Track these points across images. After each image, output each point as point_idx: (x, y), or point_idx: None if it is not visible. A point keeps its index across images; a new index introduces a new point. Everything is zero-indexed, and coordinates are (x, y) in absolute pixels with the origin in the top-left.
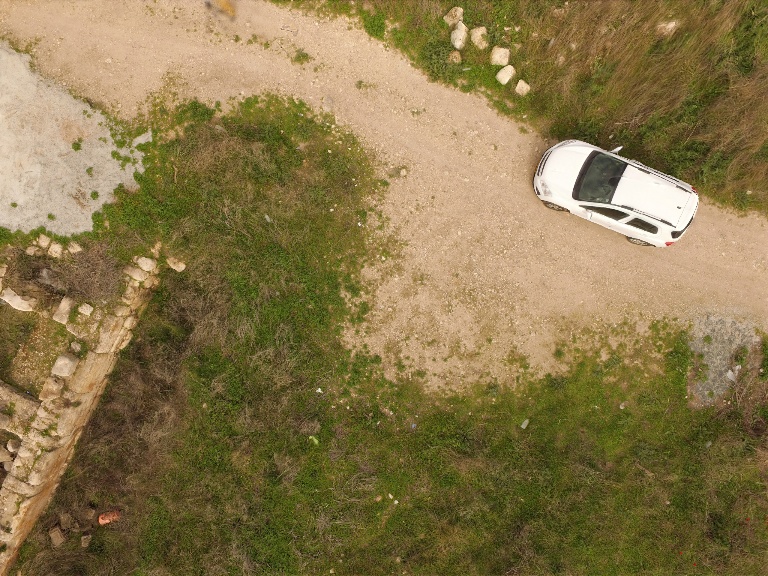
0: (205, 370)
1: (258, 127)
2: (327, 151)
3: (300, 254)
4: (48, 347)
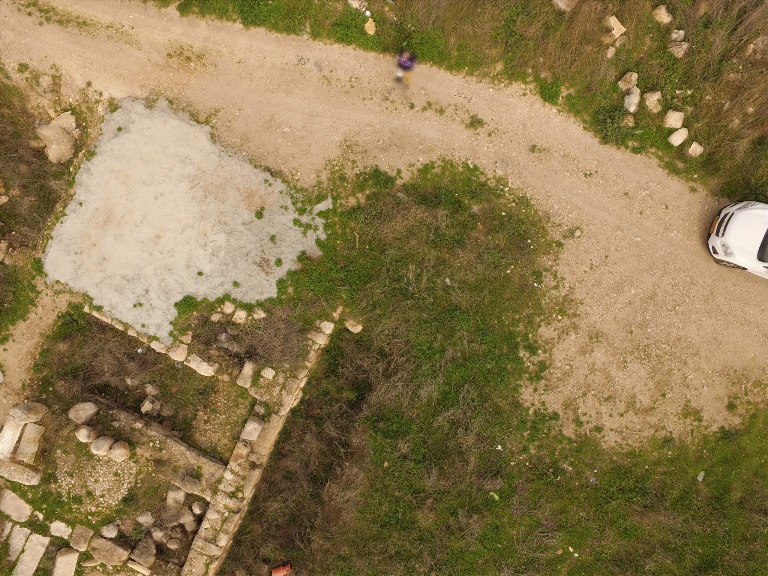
0: (388, 430)
1: (434, 191)
2: (501, 213)
3: (481, 316)
4: (229, 410)
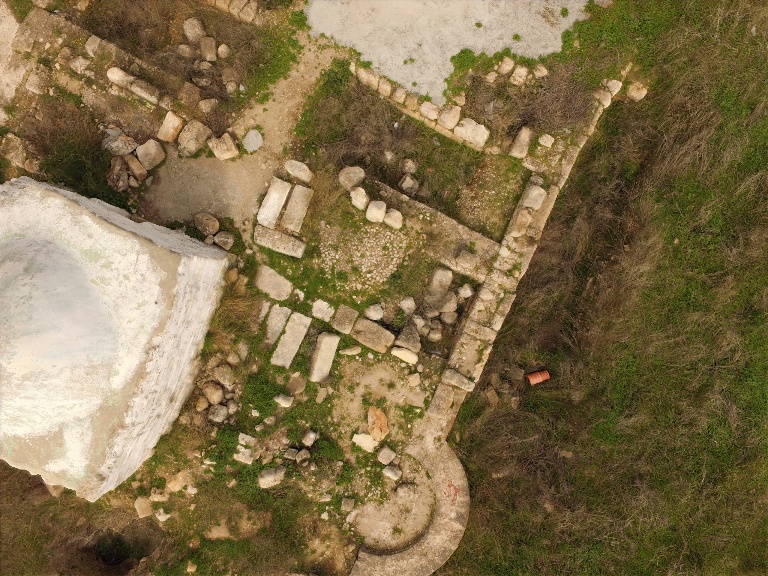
0: (683, 200)
1: None
2: None
3: None
4: (499, 185)
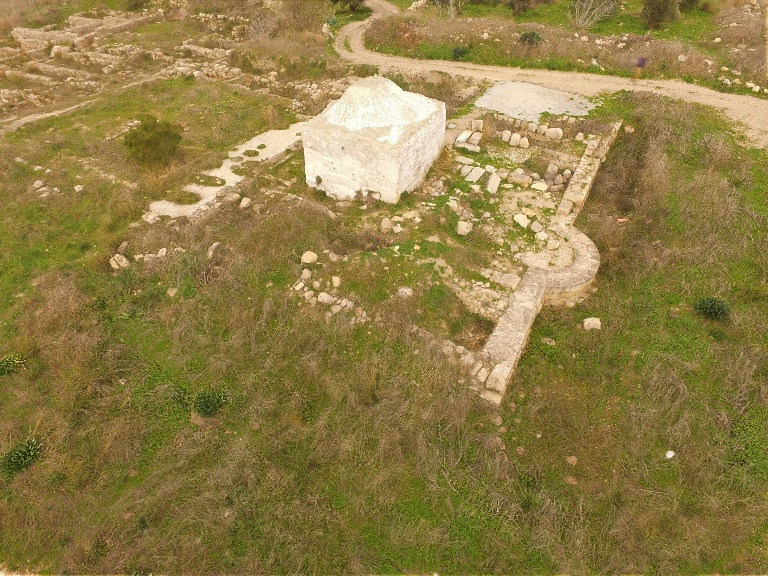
0: None
1: None
2: None
3: None
4: (573, 148)
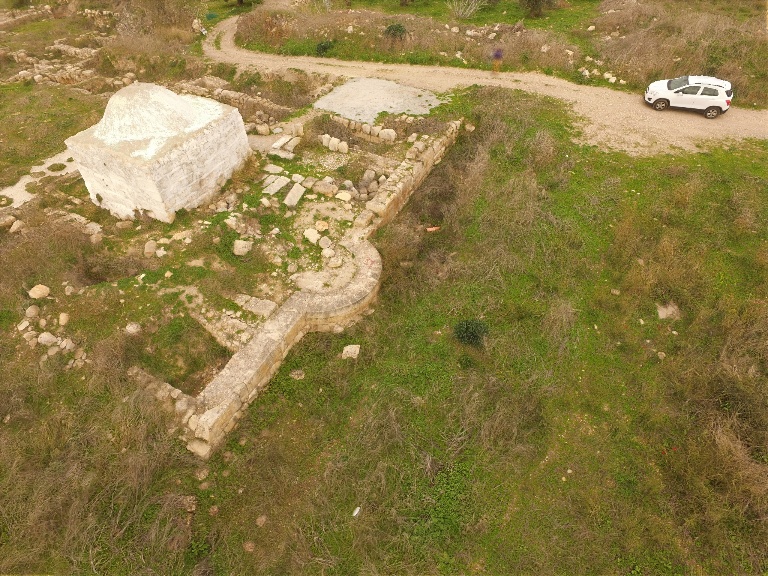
0: None
1: None
2: None
3: None
4: None
